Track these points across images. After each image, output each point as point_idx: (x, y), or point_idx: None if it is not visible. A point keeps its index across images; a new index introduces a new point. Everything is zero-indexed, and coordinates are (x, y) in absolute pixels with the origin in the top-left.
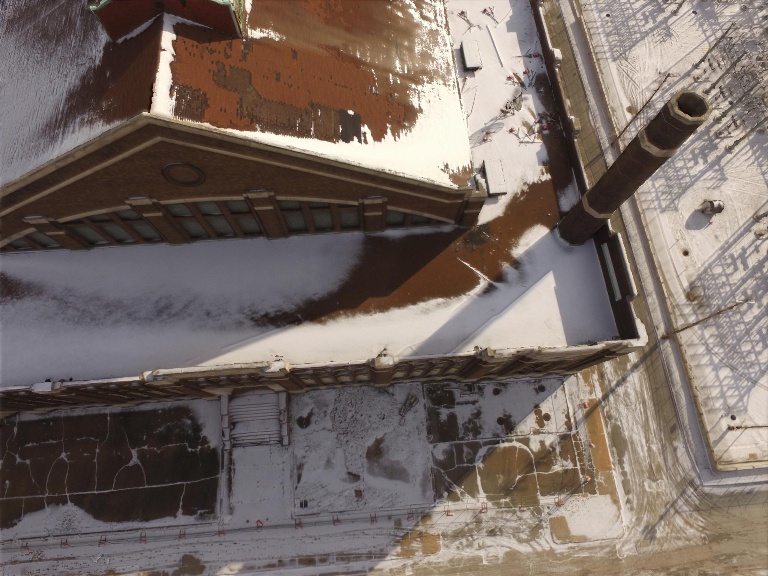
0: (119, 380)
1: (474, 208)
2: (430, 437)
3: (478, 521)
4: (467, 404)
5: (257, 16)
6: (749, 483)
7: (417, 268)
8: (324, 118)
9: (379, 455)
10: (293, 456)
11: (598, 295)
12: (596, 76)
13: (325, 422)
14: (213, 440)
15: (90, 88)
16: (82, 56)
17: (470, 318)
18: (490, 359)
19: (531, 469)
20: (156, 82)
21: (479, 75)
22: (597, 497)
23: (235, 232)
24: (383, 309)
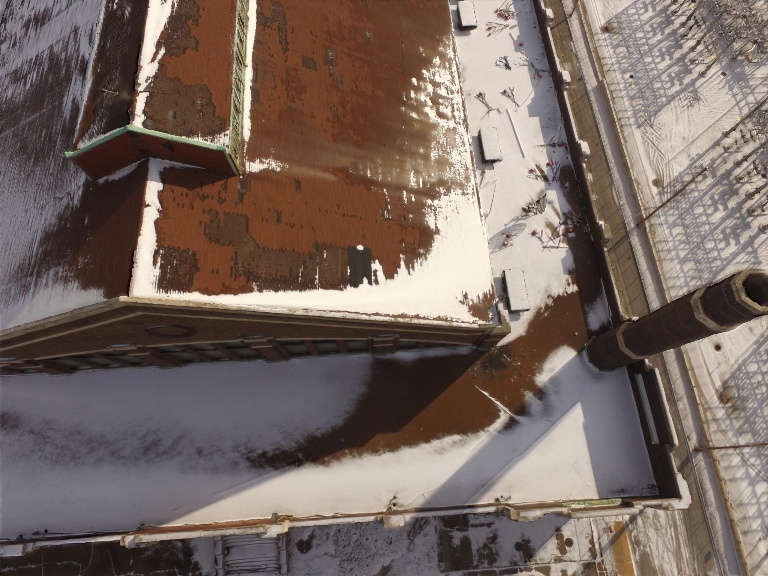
0: (98, 540)
1: (495, 338)
2: (441, 565)
3: None
4: (482, 526)
5: (256, 144)
6: None
7: (431, 397)
8: (330, 260)
9: None
10: None
11: (631, 432)
12: (620, 147)
13: (327, 546)
14: (205, 566)
15: (66, 233)
16: (60, 187)
17: (489, 459)
18: None
19: None
20: (137, 249)
21: (498, 167)
22: None
23: (231, 357)
24: (393, 448)
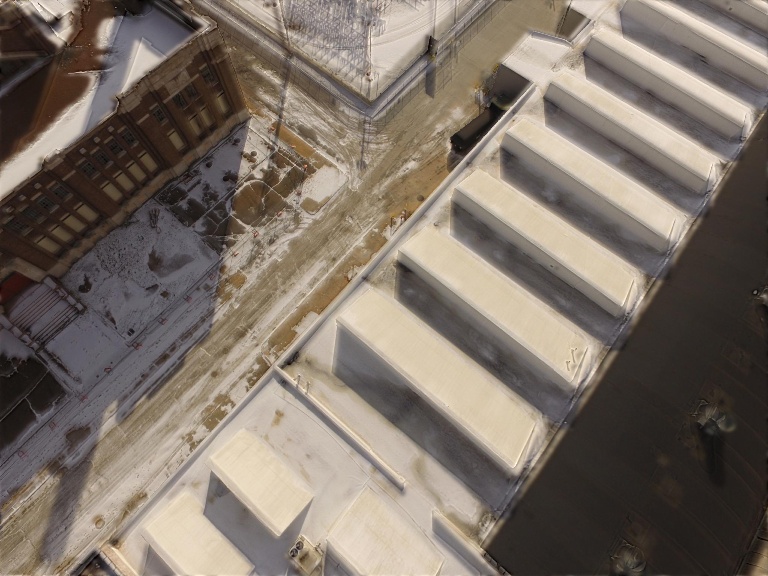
0: None
1: (39, 24)
2: (185, 223)
3: (257, 243)
4: (195, 186)
5: None
6: (395, 97)
7: (44, 99)
8: None
9: (159, 262)
10: (96, 313)
11: (184, 31)
12: None
13: (102, 275)
14: (23, 355)
15: None
16: None
17: (106, 100)
18: (127, 103)
19: (267, 189)
20: None
21: None
22: (318, 172)
23: None
24: (37, 138)
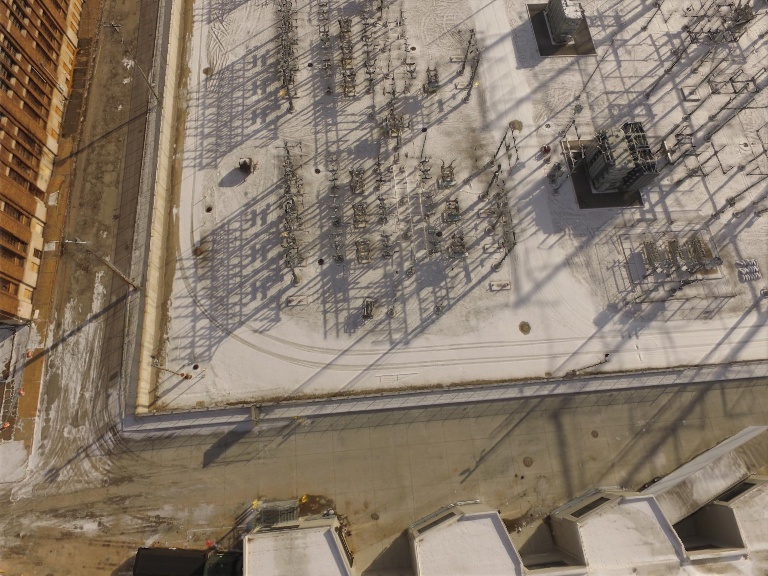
0: None
1: None
2: None
3: None
4: None
5: None
6: (169, 428)
7: None
8: None
9: None
10: None
11: None
12: None
13: None
14: None
15: None
16: None
17: None
18: None
19: None
20: None
21: None
22: (10, 443)
23: None
24: None
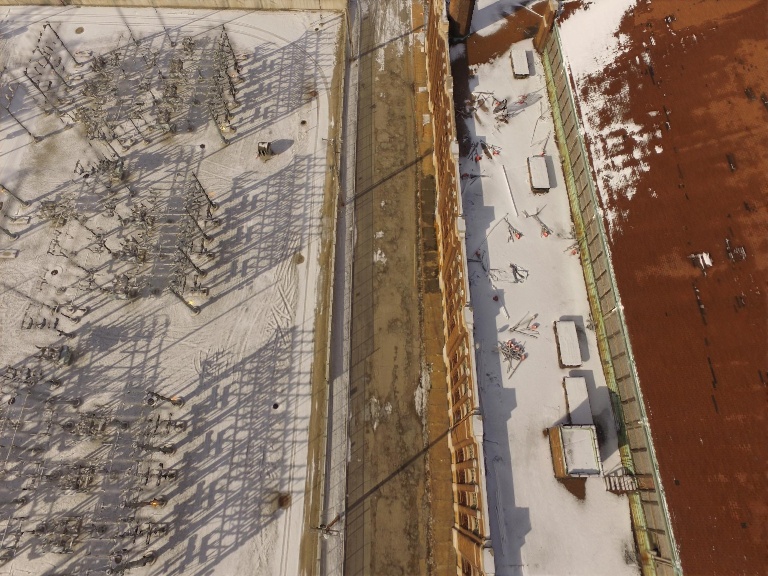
0: None
1: None
2: None
3: None
4: None
5: None
6: None
7: None
8: None
9: None
10: None
11: None
12: None
13: None
14: None
15: None
16: None
17: None
18: None
19: None
20: None
21: None
22: None
23: None
24: None
